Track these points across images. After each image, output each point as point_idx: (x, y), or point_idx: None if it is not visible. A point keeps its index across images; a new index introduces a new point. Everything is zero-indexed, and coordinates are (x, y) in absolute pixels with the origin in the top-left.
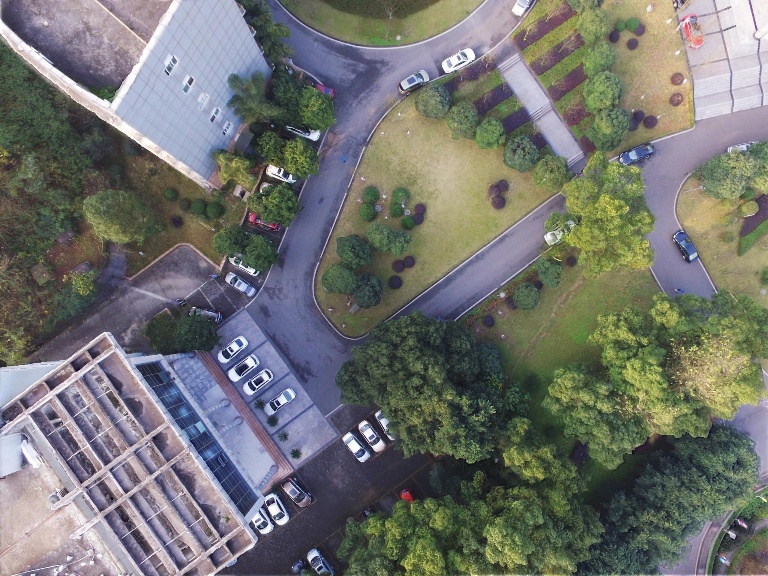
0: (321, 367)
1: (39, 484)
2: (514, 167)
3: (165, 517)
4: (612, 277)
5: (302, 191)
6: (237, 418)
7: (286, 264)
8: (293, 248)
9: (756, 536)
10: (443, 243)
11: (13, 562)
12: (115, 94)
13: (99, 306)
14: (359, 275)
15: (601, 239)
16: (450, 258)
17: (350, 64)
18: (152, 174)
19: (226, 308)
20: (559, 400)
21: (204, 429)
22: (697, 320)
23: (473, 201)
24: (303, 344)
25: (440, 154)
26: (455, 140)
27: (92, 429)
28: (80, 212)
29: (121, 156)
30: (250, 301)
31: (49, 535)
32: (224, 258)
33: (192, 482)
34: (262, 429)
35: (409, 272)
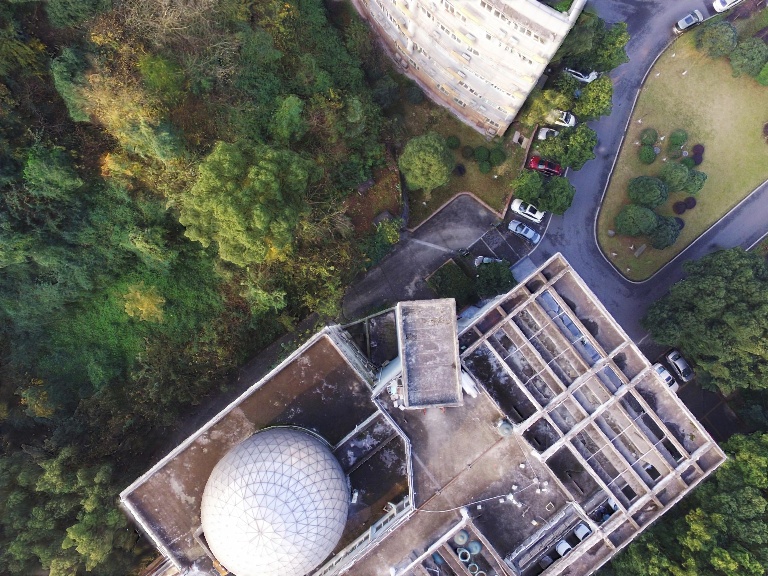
0: None
1: (476, 414)
2: None
3: (627, 438)
4: None
5: None
6: None
7: (566, 210)
8: None
9: None
10: (721, 183)
11: (456, 495)
12: (572, 6)
13: (380, 260)
14: (656, 215)
15: None
16: (728, 198)
17: (621, 6)
18: (434, 122)
19: (508, 257)
20: None
21: None
22: None
23: (749, 140)
24: None
25: (715, 94)
26: (730, 79)
27: (547, 352)
28: (382, 160)
29: (400, 105)
30: (533, 249)
31: (491, 465)
32: (506, 206)
33: (653, 401)
34: None
35: (689, 213)
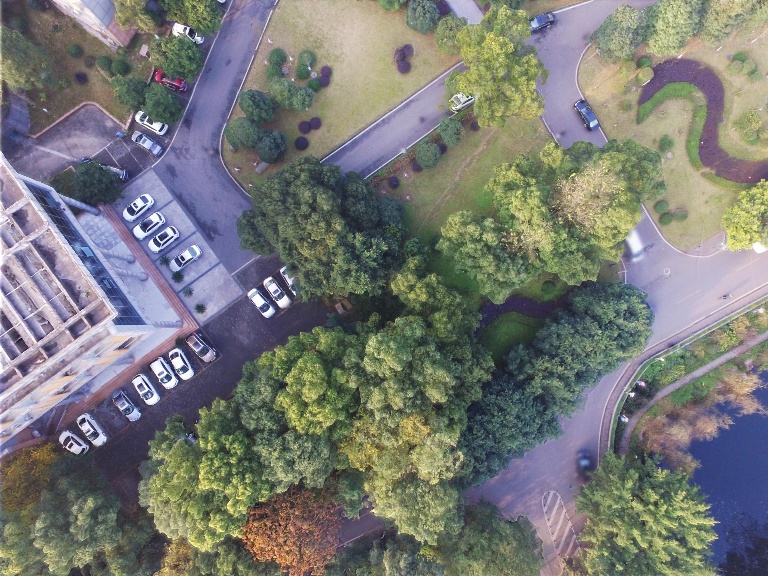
0: (228, 226)
1: None
2: (417, 29)
3: (25, 292)
4: (515, 143)
5: (210, 53)
6: (141, 273)
7: (193, 125)
8: (200, 109)
9: (658, 401)
10: (349, 106)
11: None
12: None
13: None
14: (262, 128)
15: (489, 79)
16: (356, 121)
17: None
18: (56, 31)
19: (133, 168)
20: (450, 239)
21: (91, 254)
22: (582, 160)
23: (379, 65)
24: (210, 204)
25: (346, 18)
26: (361, 5)
27: None
28: None
29: (25, 13)
30: (157, 161)
31: None
32: (130, 117)
33: (52, 258)
34: (168, 286)
35: (316, 134)
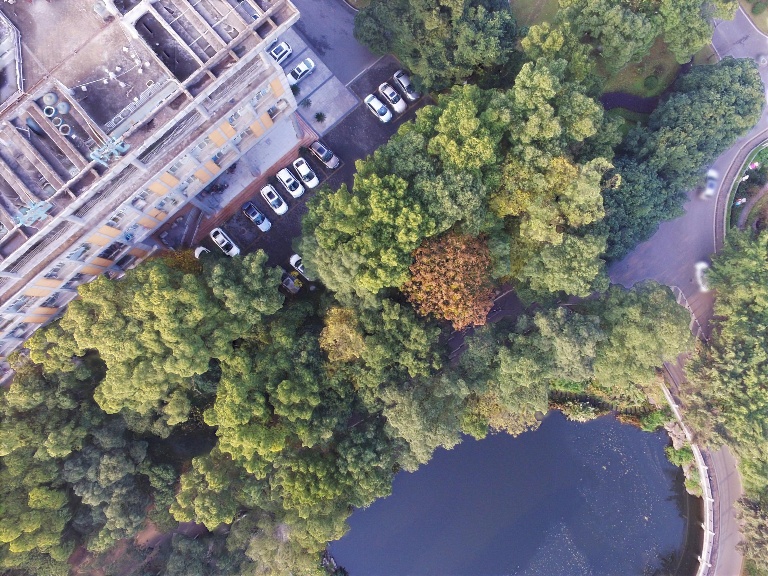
0: (337, 40)
1: (83, 6)
2: None
3: (209, 3)
4: None
5: None
6: None
7: None
8: None
9: (767, 191)
10: None
11: (63, 79)
12: None
13: None
14: None
15: None
16: None
17: None
18: None
19: None
20: None
21: None
22: None
23: None
24: (318, 21)
25: None
26: None
27: None
28: None
29: None
30: None
31: (96, 51)
32: None
33: None
34: None
35: None
